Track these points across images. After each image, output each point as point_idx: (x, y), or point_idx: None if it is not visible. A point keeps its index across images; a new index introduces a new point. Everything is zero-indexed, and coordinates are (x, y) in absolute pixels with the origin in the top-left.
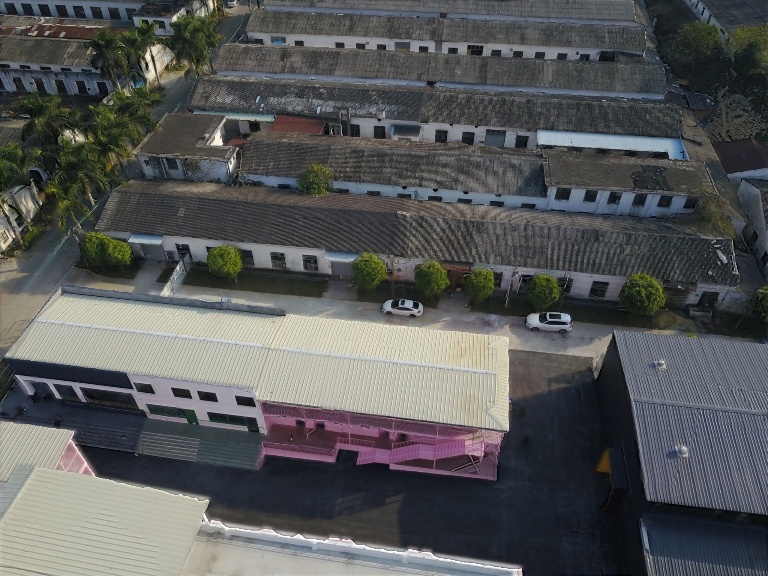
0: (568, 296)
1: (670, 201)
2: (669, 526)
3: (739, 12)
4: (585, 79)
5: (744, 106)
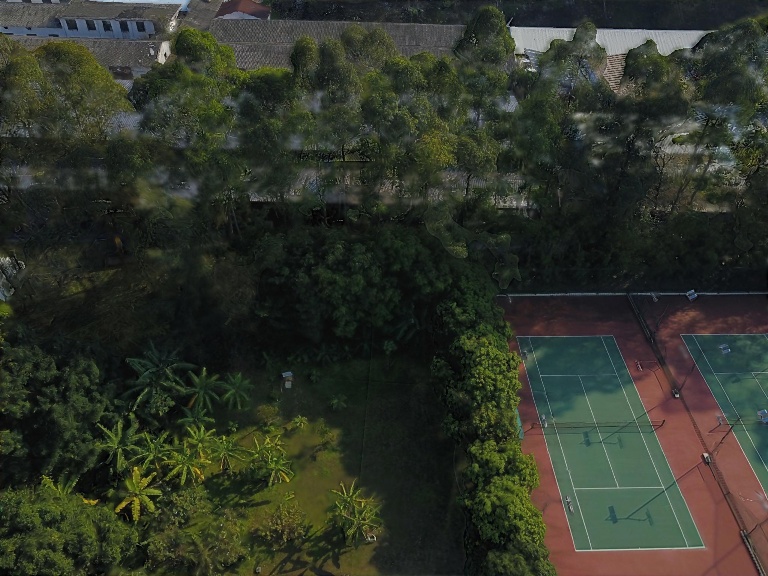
0: None
1: (144, 26)
2: None
3: None
4: None
5: None
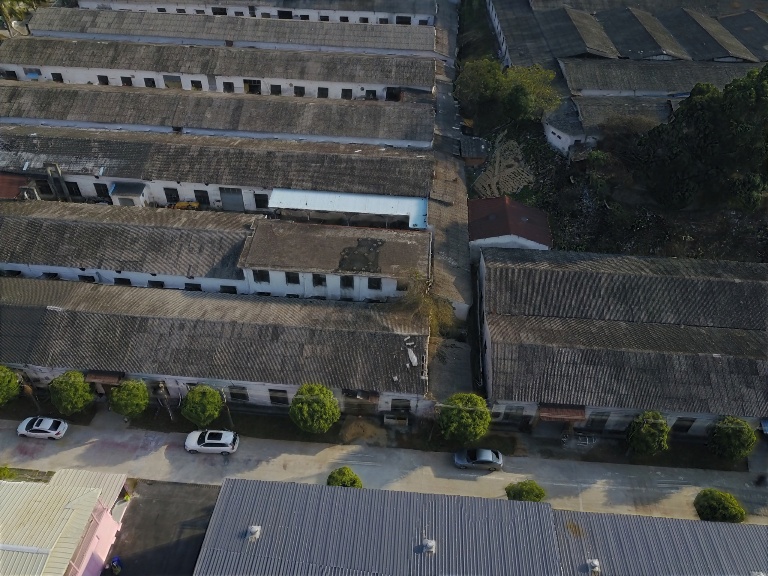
0: (249, 403)
1: (380, 283)
2: None
3: (533, 45)
4: (347, 124)
5: (516, 155)
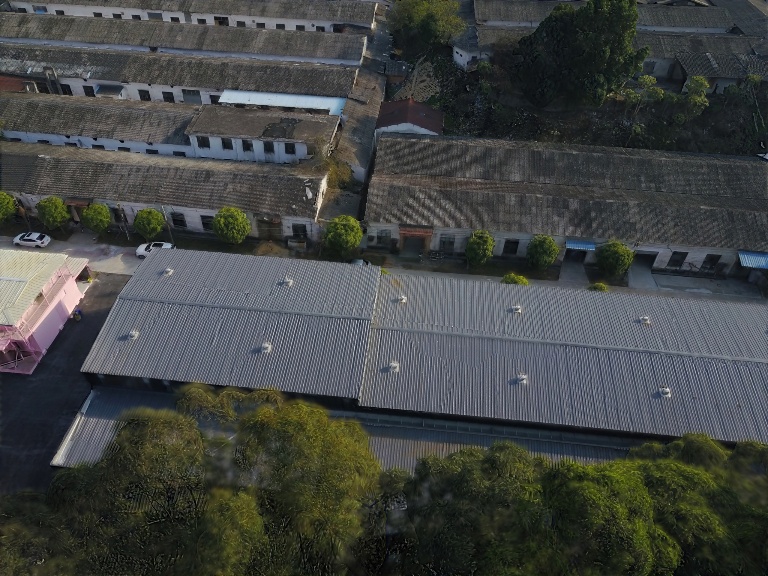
0: (187, 230)
1: (294, 148)
2: (112, 395)
3: None
4: (291, 46)
5: (428, 72)
